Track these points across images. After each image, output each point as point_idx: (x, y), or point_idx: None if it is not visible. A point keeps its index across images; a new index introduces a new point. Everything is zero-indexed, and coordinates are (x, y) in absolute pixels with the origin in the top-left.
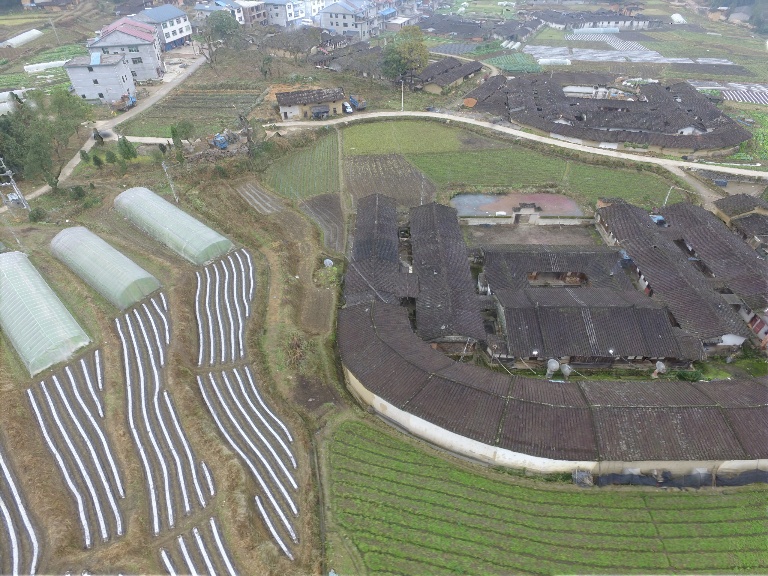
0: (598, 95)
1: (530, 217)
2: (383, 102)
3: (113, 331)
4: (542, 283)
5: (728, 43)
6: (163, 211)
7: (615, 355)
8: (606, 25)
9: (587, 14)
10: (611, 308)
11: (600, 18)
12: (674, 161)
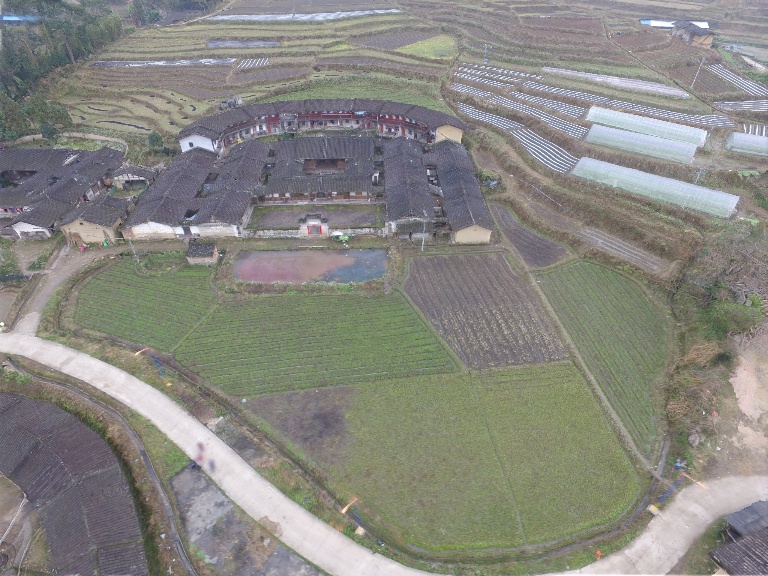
0: None
1: None
2: None
3: (583, 126)
4: None
5: None
6: (661, 178)
7: None
8: None
9: None
10: None
11: None
12: None
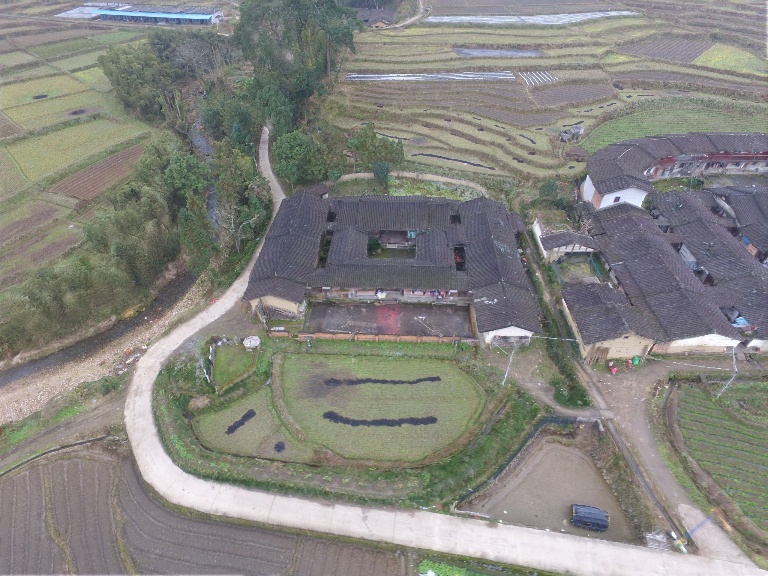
0: None
1: None
2: None
3: None
4: None
5: None
6: None
7: None
8: None
9: None
10: None
11: None
12: None
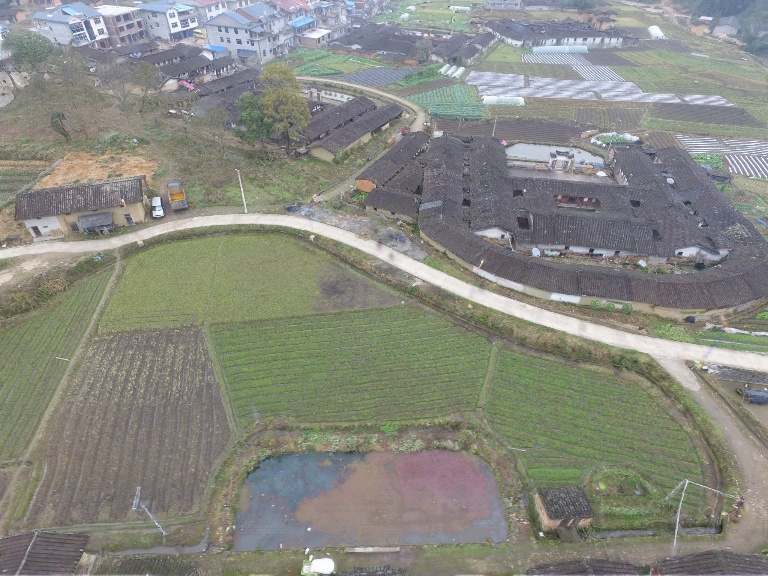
0: (557, 163)
1: None
2: (230, 188)
3: None
4: None
5: (719, 70)
6: None
7: None
8: (572, 42)
9: (550, 27)
10: None
11: (565, 33)
12: (677, 345)
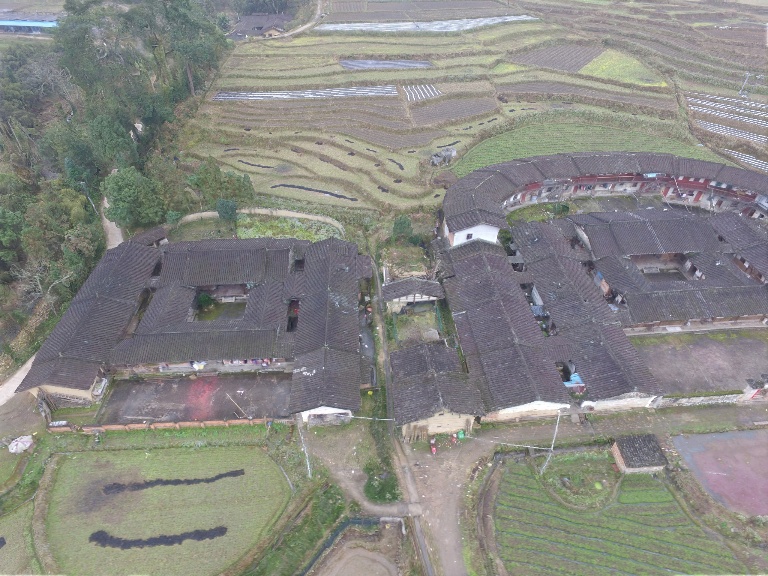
0: None
1: None
2: None
3: None
4: None
5: None
6: None
7: None
8: None
9: None
10: None
11: None
12: None
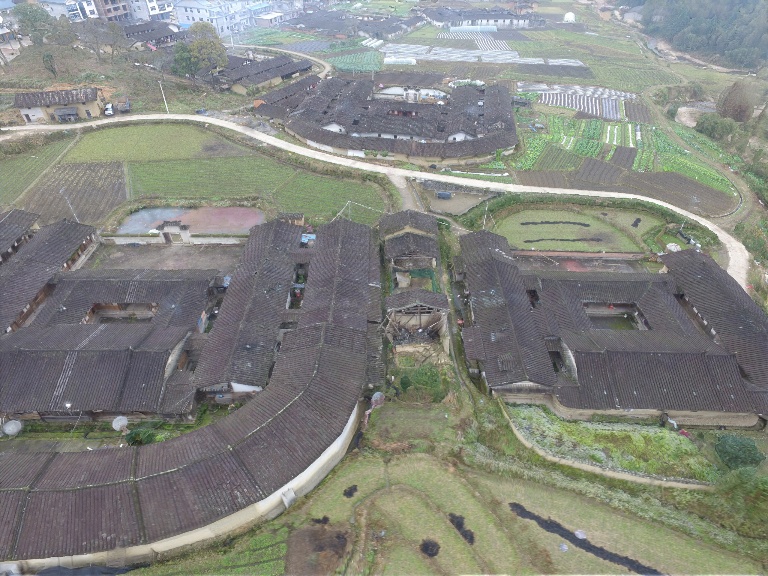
0: (413, 97)
1: (181, 236)
2: (163, 103)
3: None
4: (127, 314)
5: (597, 43)
6: None
7: (74, 409)
8: (485, 23)
9: (472, 12)
10: (103, 352)
11: (479, 16)
12: (406, 171)
